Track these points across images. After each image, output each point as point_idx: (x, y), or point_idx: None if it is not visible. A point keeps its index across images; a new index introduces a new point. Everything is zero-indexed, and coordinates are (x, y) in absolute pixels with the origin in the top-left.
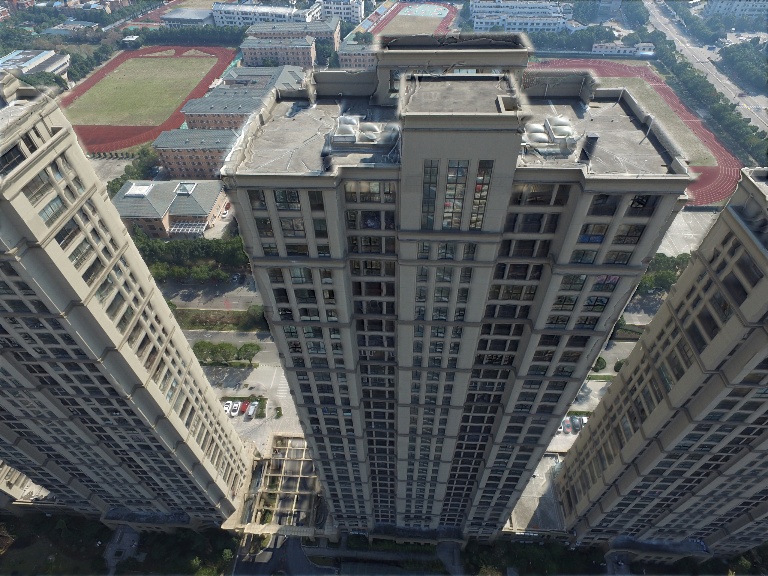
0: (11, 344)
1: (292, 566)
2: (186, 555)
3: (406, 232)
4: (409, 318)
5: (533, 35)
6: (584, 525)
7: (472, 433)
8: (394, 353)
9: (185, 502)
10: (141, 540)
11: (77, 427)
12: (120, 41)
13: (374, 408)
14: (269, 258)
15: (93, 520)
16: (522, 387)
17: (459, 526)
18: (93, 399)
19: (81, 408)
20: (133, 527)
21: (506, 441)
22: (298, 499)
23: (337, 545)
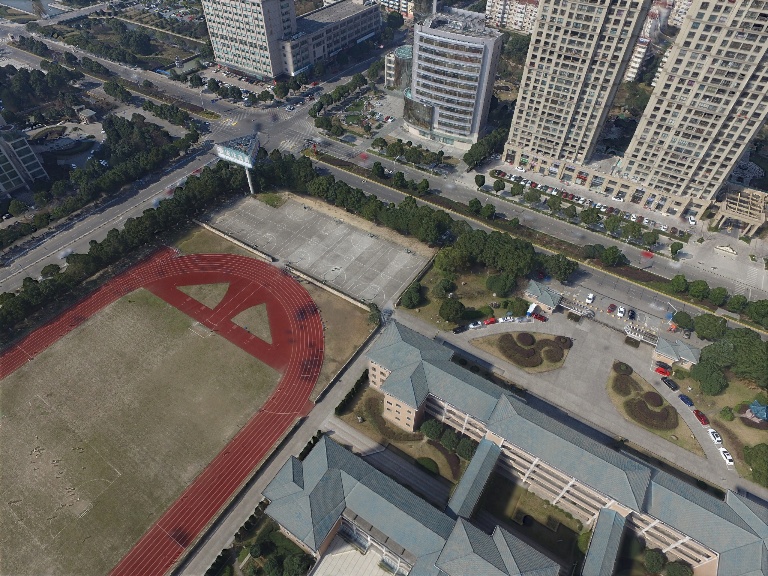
0: None
1: None
2: None
3: None
4: None
5: None
6: None
7: None
8: None
9: None
10: None
11: None
12: None
13: None
14: None
15: None
16: None
17: None
18: None
19: None
20: None
21: None
22: None
23: None
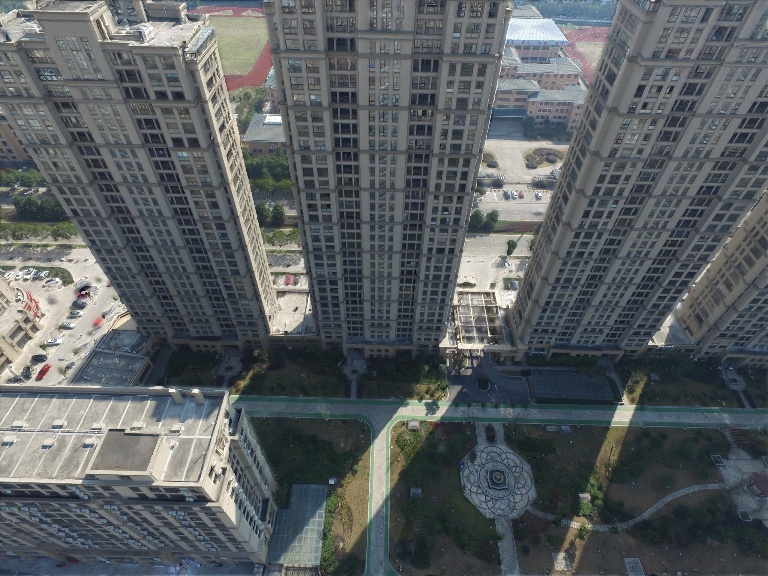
0: (415, 146)
1: (490, 376)
2: (411, 369)
3: (742, 39)
4: (705, 111)
5: (570, 4)
6: (714, 332)
7: (682, 228)
8: (673, 147)
9: (422, 321)
10: (370, 362)
11: (400, 232)
12: (178, 0)
13: (628, 204)
14: (653, 59)
15: (327, 350)
16: (745, 173)
17: (616, 342)
18: (442, 197)
19: (414, 213)
20: (366, 351)
21: (707, 231)
22: (490, 329)
23: (520, 363)
